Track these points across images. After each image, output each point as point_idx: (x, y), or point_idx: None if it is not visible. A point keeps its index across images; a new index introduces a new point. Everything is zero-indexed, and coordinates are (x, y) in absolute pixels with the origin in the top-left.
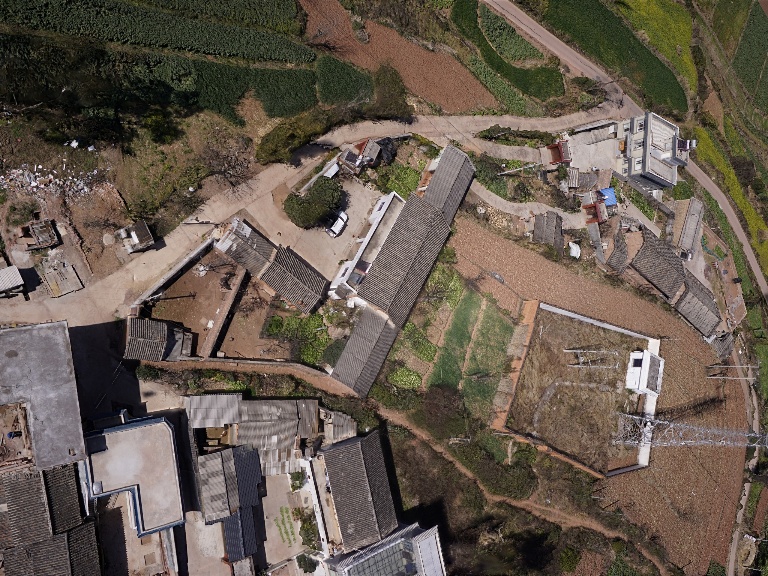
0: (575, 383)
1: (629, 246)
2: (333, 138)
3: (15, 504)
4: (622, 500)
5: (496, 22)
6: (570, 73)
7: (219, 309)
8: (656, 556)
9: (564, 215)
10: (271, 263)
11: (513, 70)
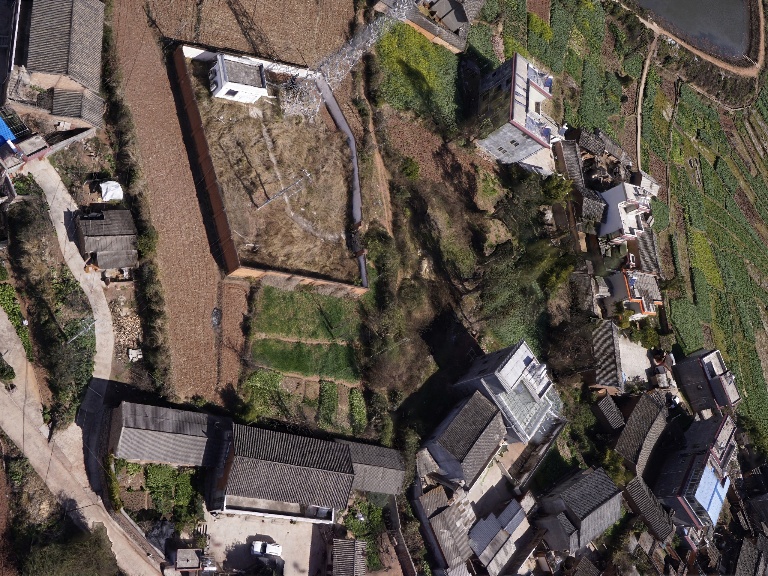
0: (281, 186)
1: (57, 87)
2: None
3: None
4: (344, 97)
5: None
6: None
7: None
8: None
9: (53, 205)
10: None
11: None
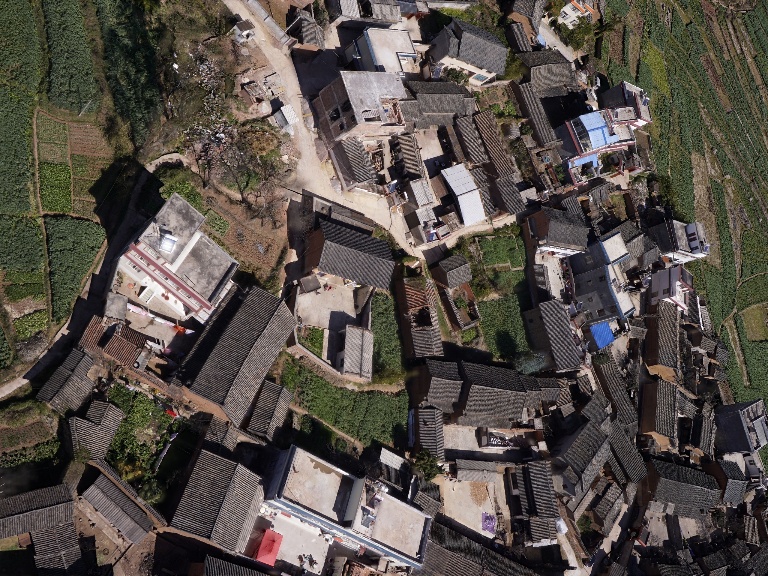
0: None
1: None
2: None
3: None
4: None
5: None
6: None
7: None
8: None
9: None
10: None
11: None
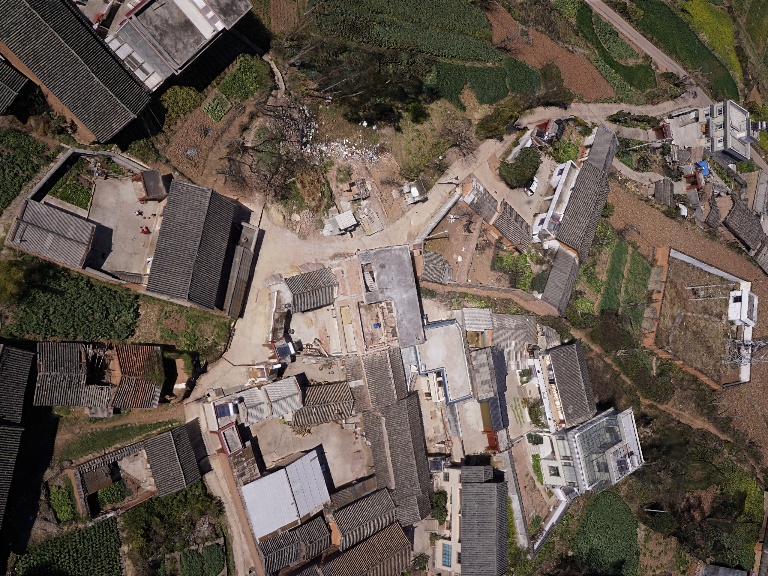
0: (694, 314)
1: (720, 208)
2: (521, 120)
3: (372, 378)
4: (730, 410)
5: (606, 28)
6: (658, 69)
7: (464, 248)
8: (752, 459)
9: None
10: (501, 212)
11: (621, 67)
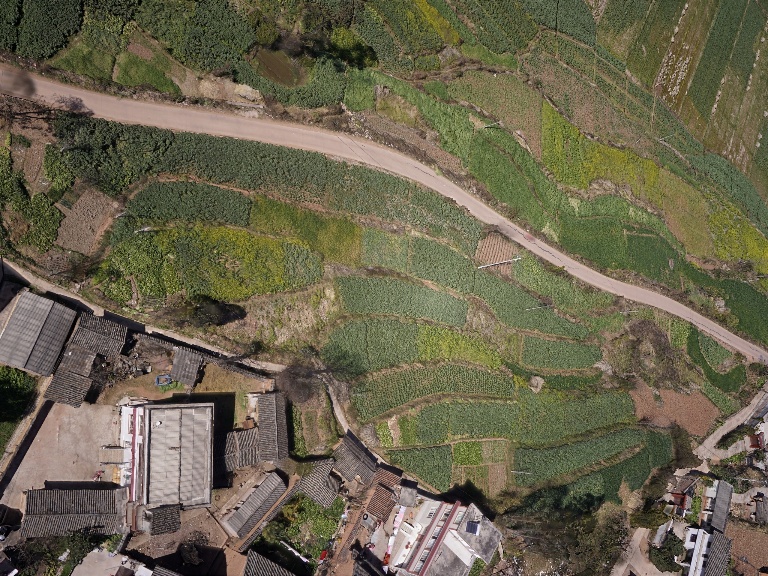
0: None
1: None
2: None
3: None
4: None
5: (709, 344)
6: (747, 361)
7: None
8: None
9: (765, 490)
10: None
11: (721, 378)
